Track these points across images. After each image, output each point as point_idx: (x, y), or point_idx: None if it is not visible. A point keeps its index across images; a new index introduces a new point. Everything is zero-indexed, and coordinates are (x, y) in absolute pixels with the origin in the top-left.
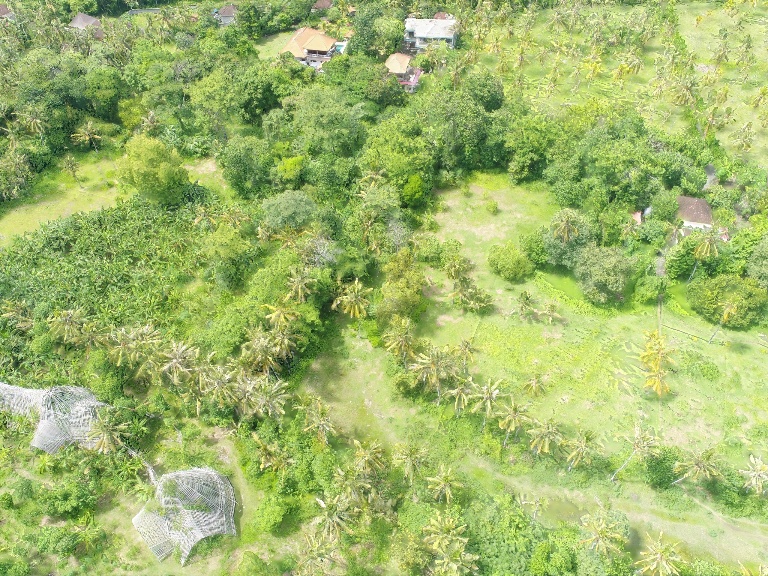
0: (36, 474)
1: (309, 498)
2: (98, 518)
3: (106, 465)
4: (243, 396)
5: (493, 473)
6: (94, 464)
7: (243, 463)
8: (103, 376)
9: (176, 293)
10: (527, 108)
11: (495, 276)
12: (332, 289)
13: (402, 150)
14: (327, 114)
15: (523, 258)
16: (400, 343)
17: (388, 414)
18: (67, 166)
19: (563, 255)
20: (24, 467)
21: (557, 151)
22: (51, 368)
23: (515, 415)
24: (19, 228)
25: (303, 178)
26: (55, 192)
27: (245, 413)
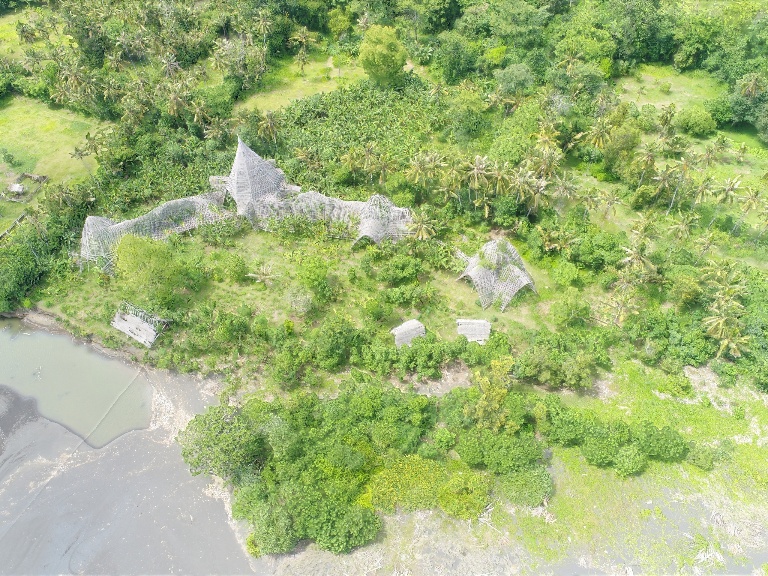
0: (360, 262)
1: (583, 273)
2: (423, 286)
3: (425, 248)
4: (537, 191)
5: (723, 256)
6: (414, 249)
7: (524, 252)
8: (402, 192)
9: (427, 145)
10: (683, 12)
11: (682, 135)
12: (568, 133)
13: (593, 39)
14: (524, 12)
15: (710, 117)
16: (647, 159)
17: (626, 222)
18: (301, 58)
19: (746, 111)
20: (348, 258)
21: (724, 39)
22: (353, 190)
23: (755, 198)
24: (264, 109)
25: (504, 66)
26: (282, 84)
27: (536, 206)
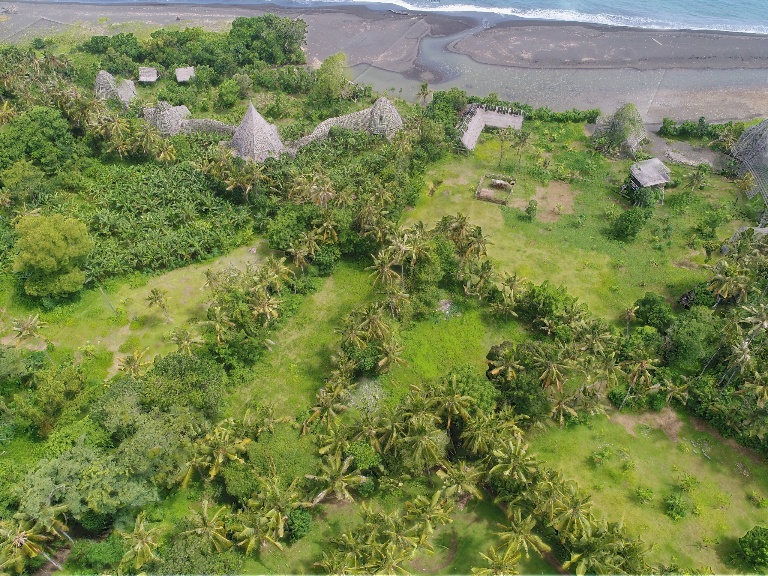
0: None
1: None
2: None
3: None
4: None
5: None
6: None
7: None
8: None
9: (87, 184)
10: None
11: None
12: None
13: None
14: None
15: None
16: None
17: None
18: None
19: None
20: None
21: None
22: None
23: None
24: None
25: None
26: None
27: None
